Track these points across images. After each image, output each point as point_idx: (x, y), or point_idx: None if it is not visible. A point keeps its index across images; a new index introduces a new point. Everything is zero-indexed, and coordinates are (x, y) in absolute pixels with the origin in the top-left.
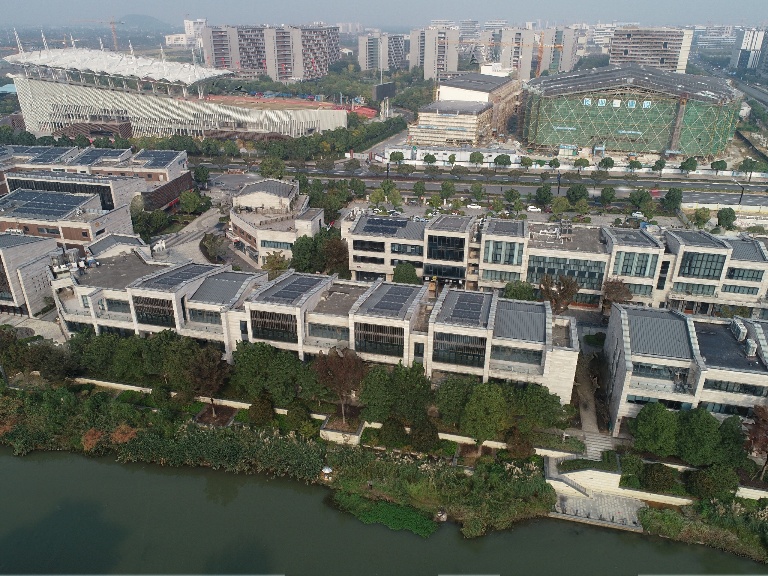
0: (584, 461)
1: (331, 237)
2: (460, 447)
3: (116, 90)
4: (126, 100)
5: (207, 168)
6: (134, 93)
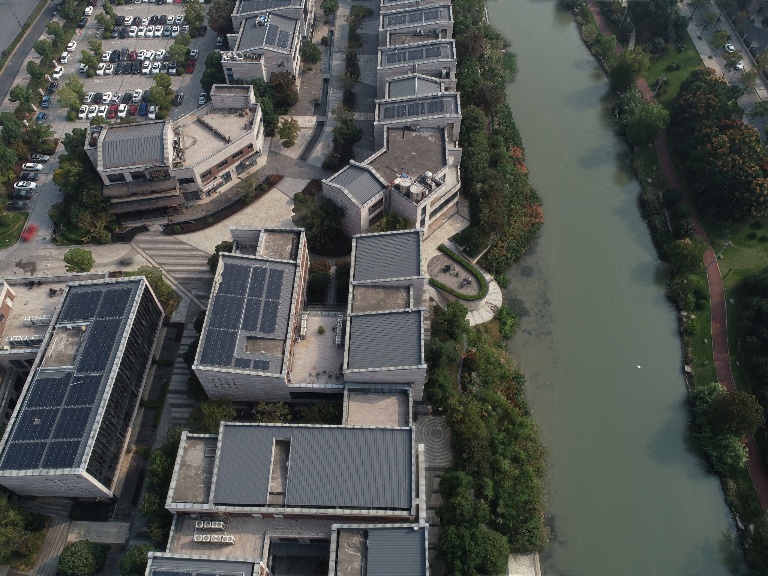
0: None
1: (263, 84)
2: None
3: None
4: None
5: None
6: None
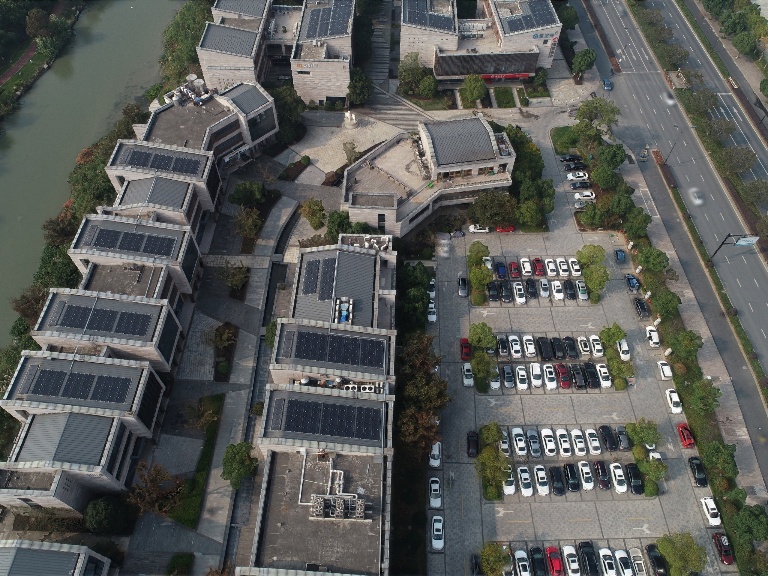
0: None
1: None
2: None
3: None
4: None
5: (594, 58)
6: None
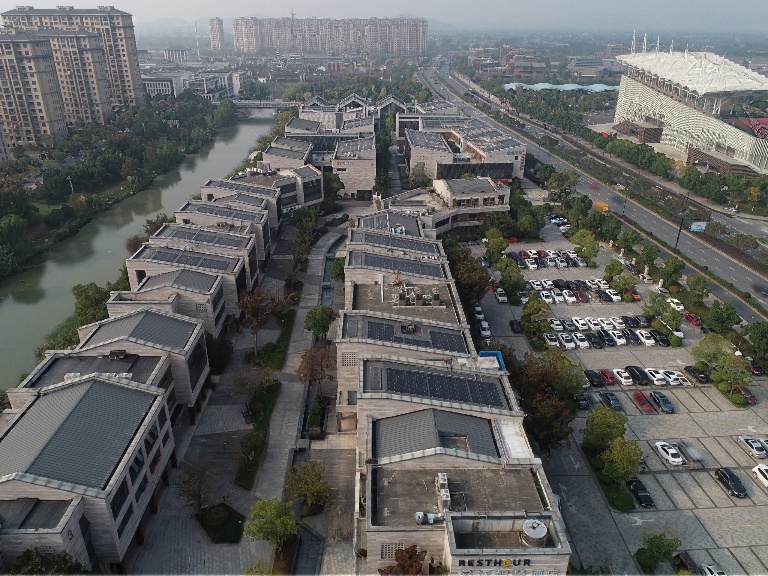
0: None
1: None
2: None
3: (666, 94)
4: (668, 105)
5: (553, 169)
6: (675, 99)
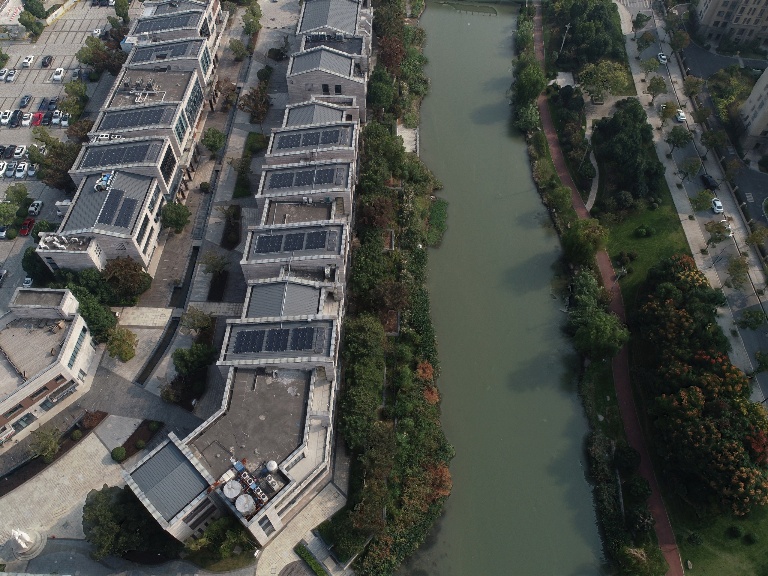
0: (393, 133)
1: (93, 277)
2: (385, 186)
3: None
4: None
5: None
6: None
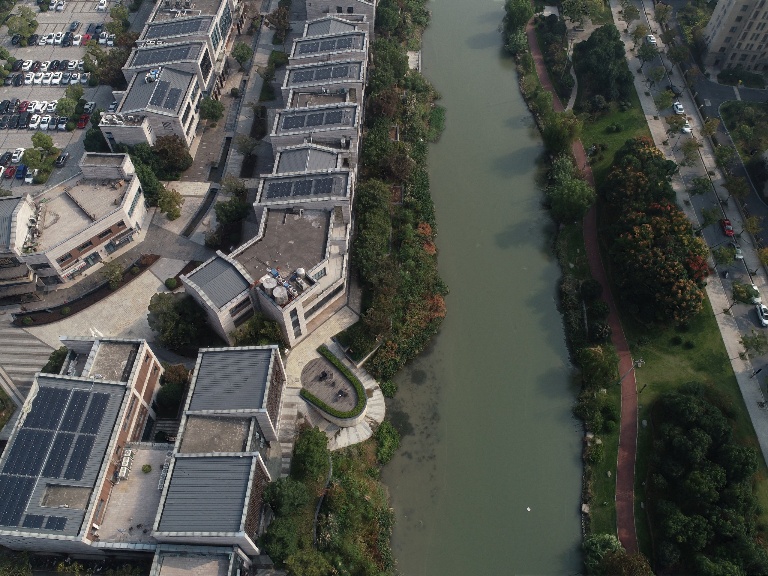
0: None
1: (146, 149)
2: None
3: None
4: None
5: None
6: None
